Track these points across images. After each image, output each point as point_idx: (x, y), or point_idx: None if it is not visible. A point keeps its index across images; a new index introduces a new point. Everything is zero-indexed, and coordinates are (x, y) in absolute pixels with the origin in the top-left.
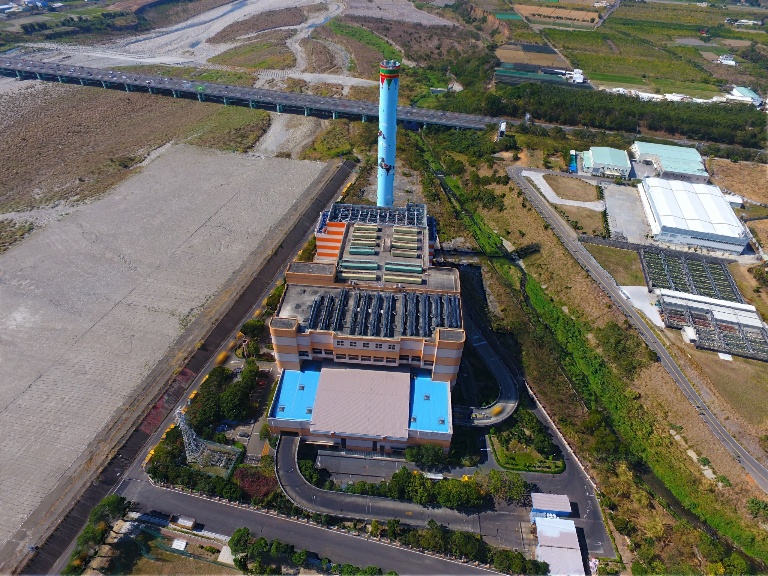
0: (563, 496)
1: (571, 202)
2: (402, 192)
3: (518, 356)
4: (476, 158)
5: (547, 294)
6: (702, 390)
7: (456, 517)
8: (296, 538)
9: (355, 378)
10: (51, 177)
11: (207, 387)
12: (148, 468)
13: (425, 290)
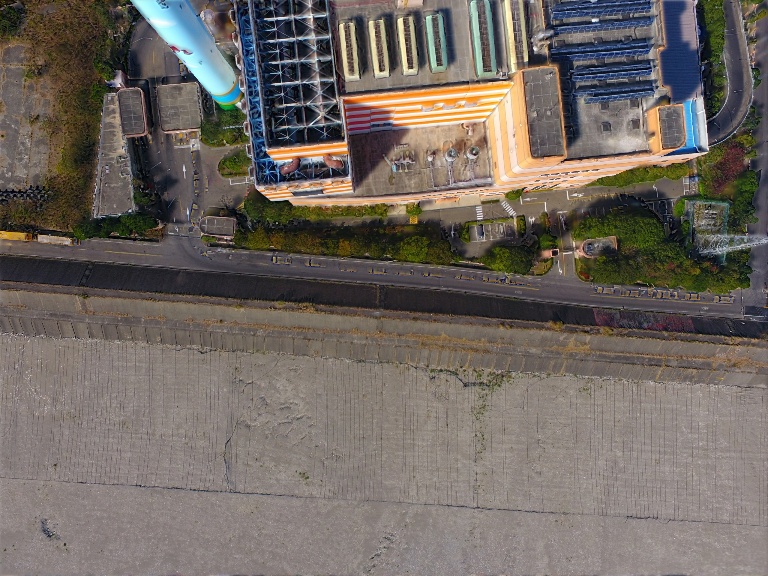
0: None
1: None
2: None
3: None
4: None
5: None
6: None
7: None
8: (767, 104)
9: None
10: None
11: None
12: None
13: None
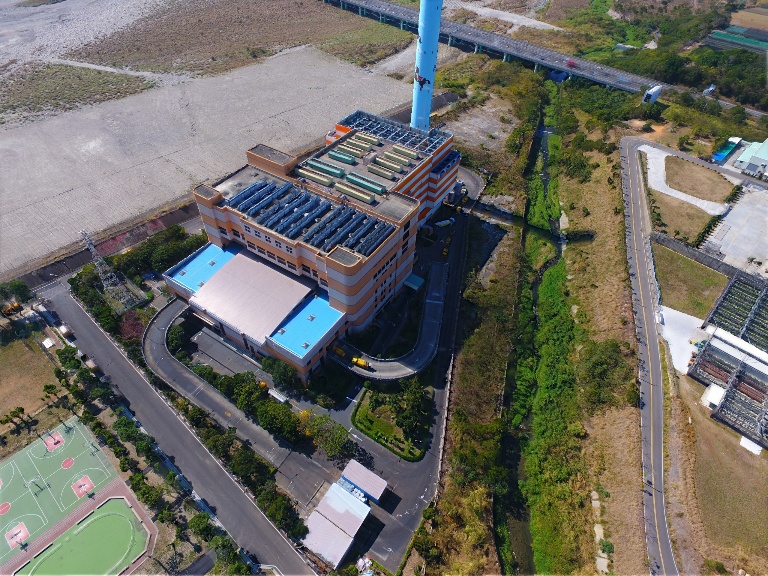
0: (382, 480)
1: (679, 194)
2: (484, 136)
3: (466, 330)
4: (600, 121)
5: (566, 285)
6: (673, 466)
7: (267, 441)
8: (126, 383)
9: (258, 272)
10: (196, 52)
11: (156, 237)
12: (70, 278)
13: (365, 209)
